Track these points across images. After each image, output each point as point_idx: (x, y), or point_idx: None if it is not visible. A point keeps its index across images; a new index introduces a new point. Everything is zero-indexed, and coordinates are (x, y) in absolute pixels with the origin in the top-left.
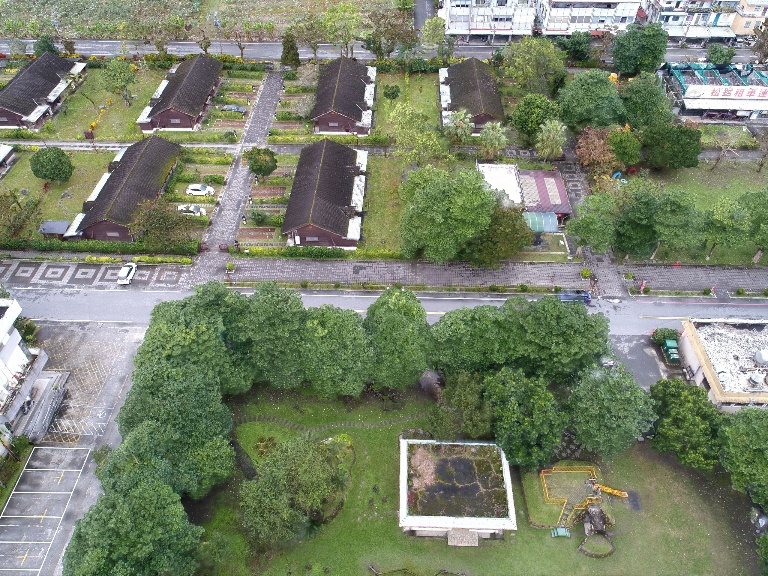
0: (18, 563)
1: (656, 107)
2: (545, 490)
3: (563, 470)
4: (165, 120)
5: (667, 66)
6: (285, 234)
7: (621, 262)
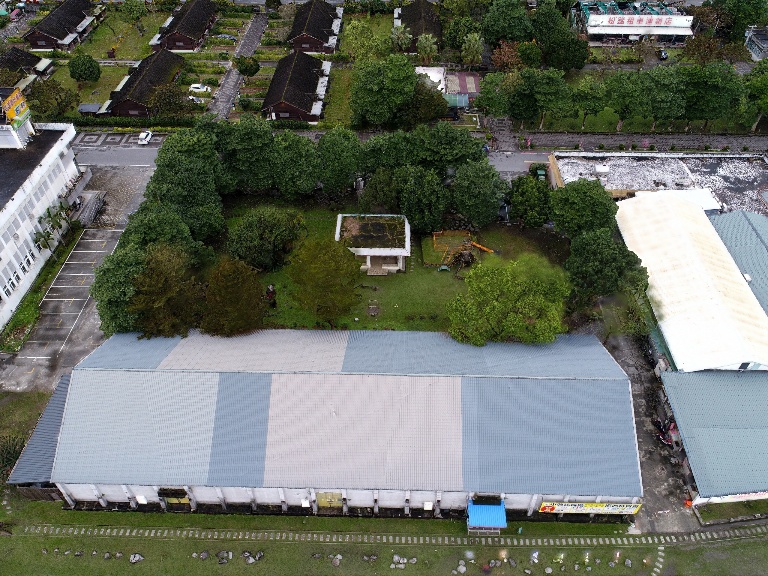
0: (79, 284)
1: (556, 26)
2: None
3: (449, 235)
4: (171, 43)
5: (579, 4)
6: (264, 111)
7: (517, 131)
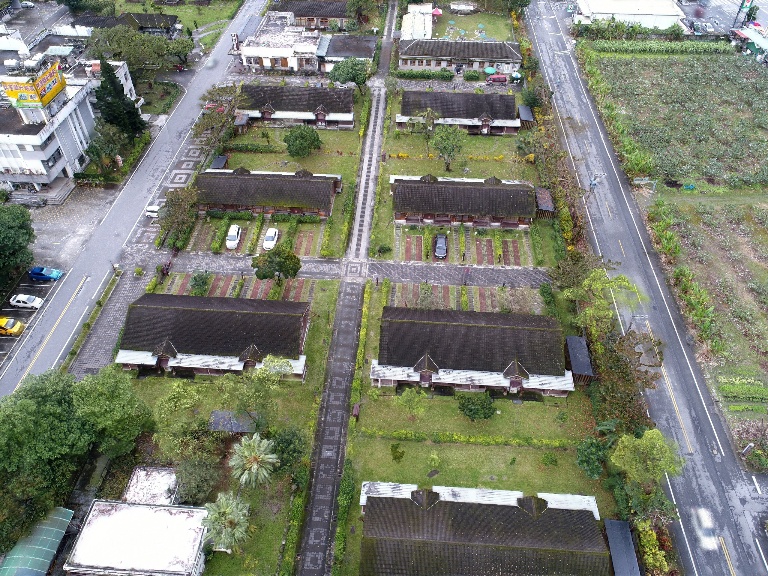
0: None
1: None
2: None
3: None
4: None
5: None
6: None
7: None
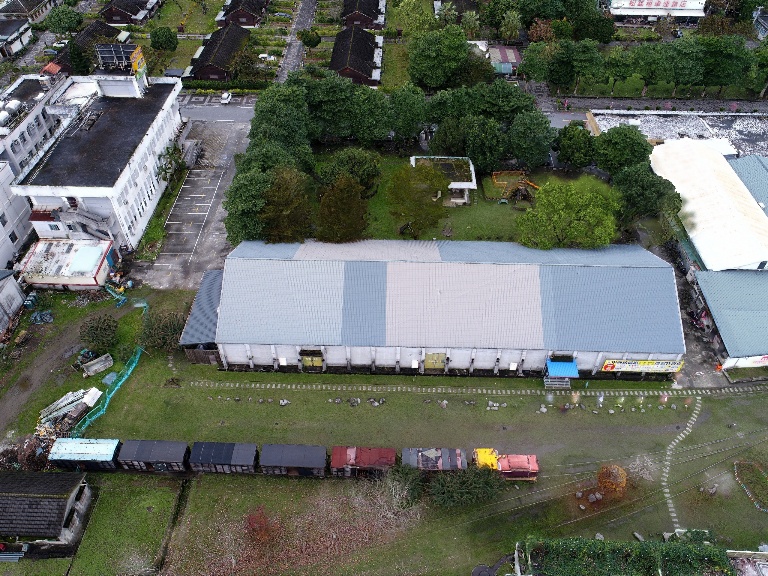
0: (194, 211)
1: (585, 5)
2: (495, 182)
3: (506, 175)
4: (235, 19)
5: None
6: None
7: (554, 95)
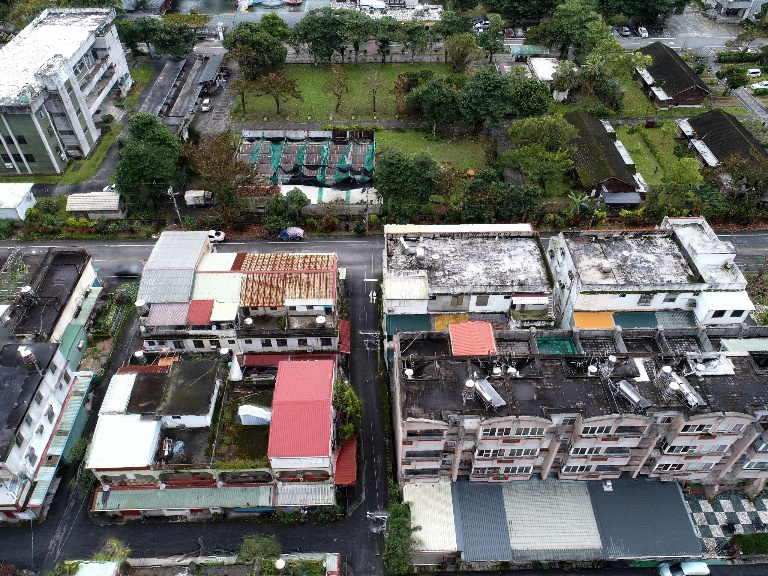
0: None
1: None
2: None
3: None
4: None
5: None
6: None
7: None
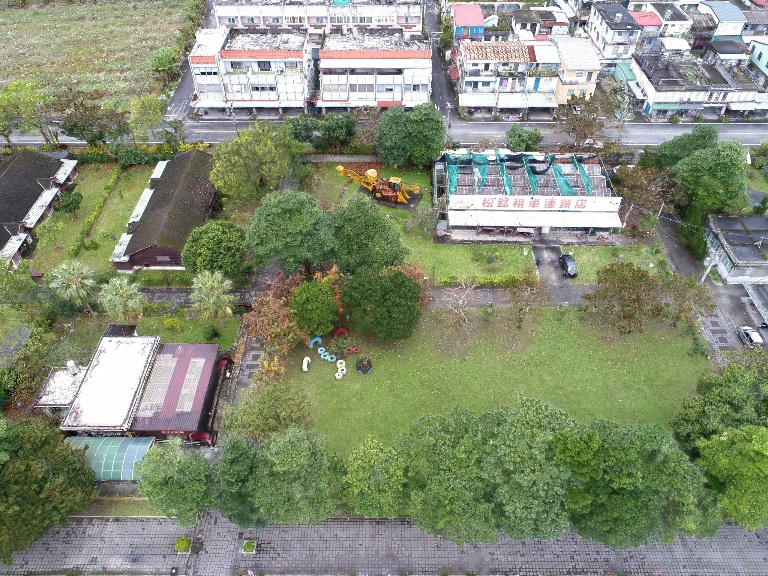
0: None
1: (372, 243)
2: None
3: None
4: None
5: None
6: None
7: None
